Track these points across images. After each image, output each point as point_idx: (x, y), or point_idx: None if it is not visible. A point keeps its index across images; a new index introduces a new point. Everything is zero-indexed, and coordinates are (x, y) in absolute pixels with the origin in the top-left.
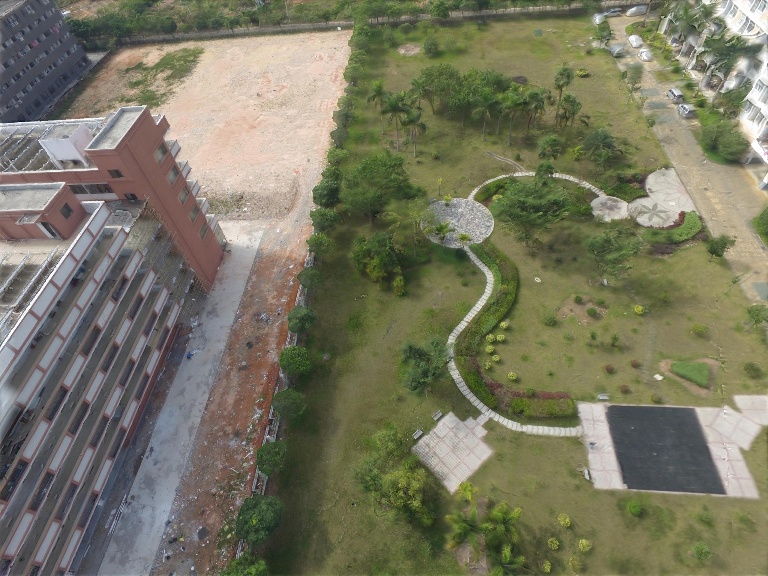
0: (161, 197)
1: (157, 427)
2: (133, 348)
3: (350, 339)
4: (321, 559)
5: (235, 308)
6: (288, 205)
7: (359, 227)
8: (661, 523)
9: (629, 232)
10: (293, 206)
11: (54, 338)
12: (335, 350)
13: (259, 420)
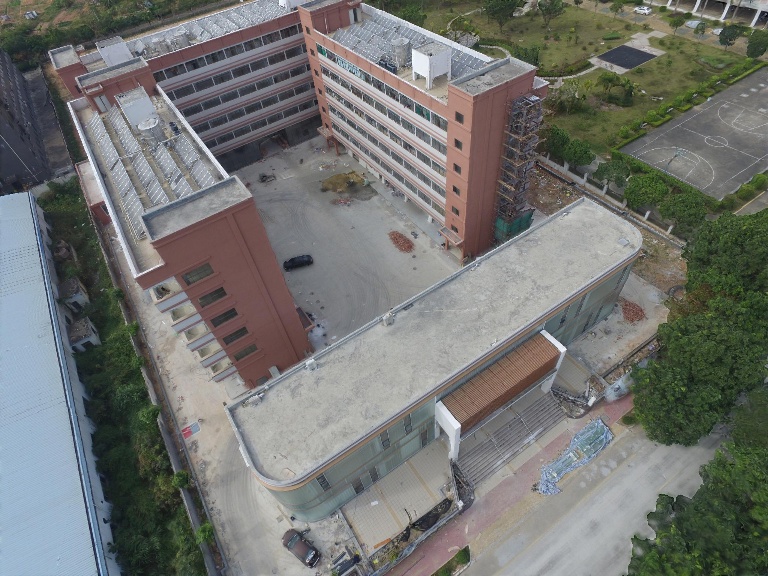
0: None
1: None
2: None
3: None
4: None
5: None
6: None
7: None
8: (649, 71)
9: None
10: None
11: None
12: None
13: None
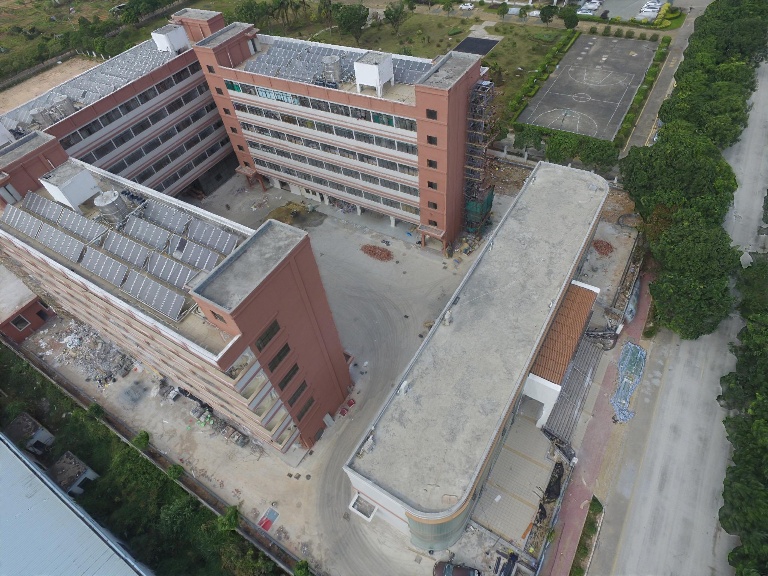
0: None
1: None
2: None
3: None
4: None
5: None
6: None
7: None
8: None
9: (393, 2)
10: None
11: None
12: None
13: None
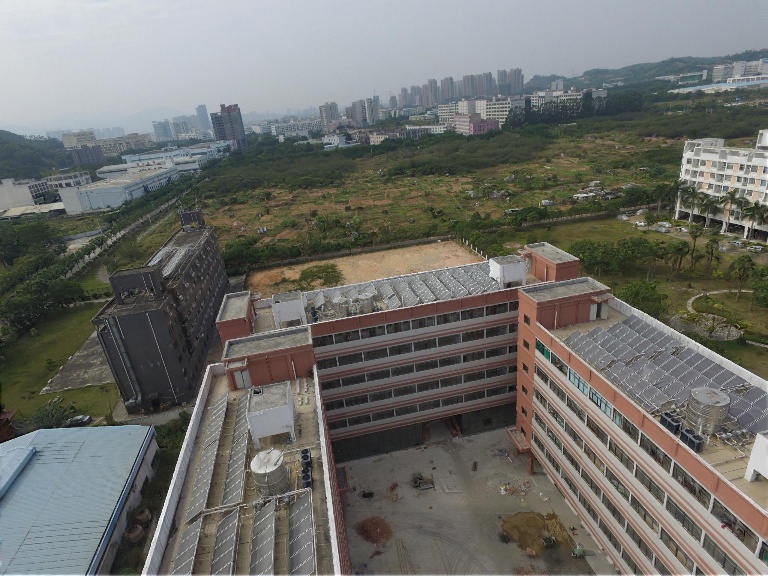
0: None
1: None
2: None
3: None
4: None
5: None
6: None
7: None
8: None
9: None
10: None
11: None
12: None
13: None
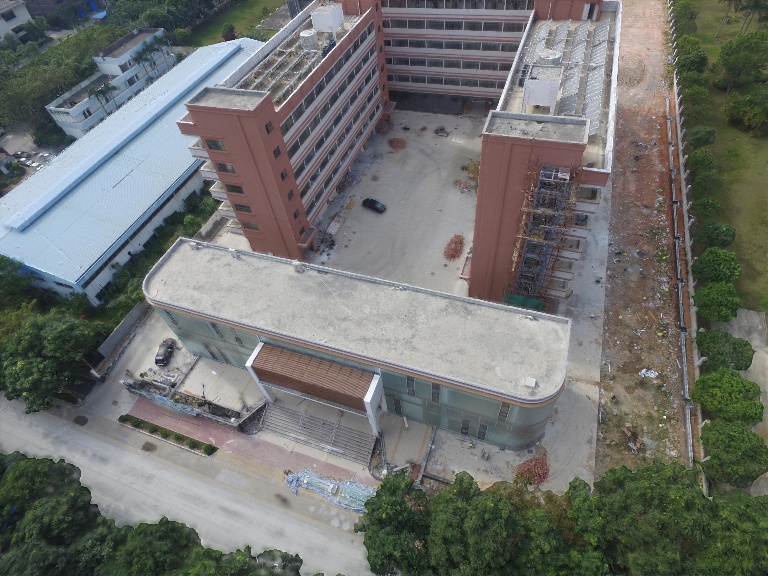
0: None
1: None
2: None
3: (733, 163)
4: (753, 277)
5: None
6: (638, 77)
7: (715, 96)
8: None
9: None
10: (642, 79)
11: None
12: (721, 168)
13: (664, 201)
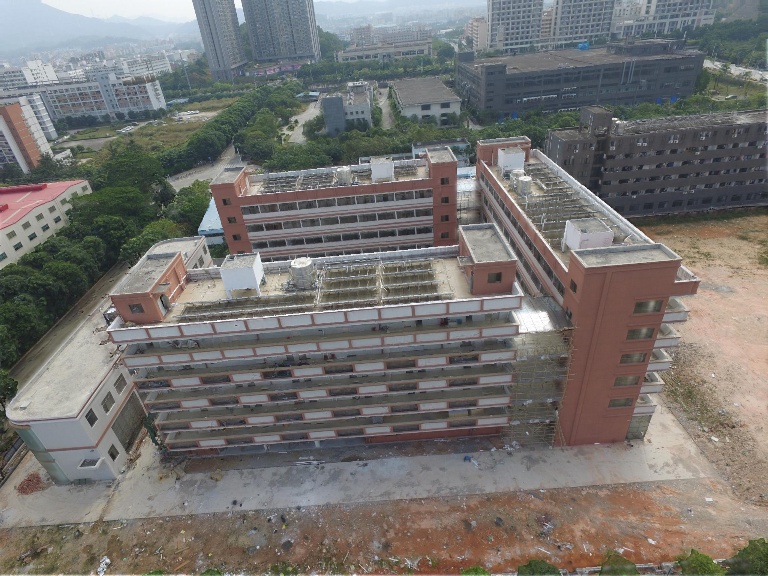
0: (597, 338)
1: (386, 460)
2: (428, 401)
3: None
4: None
5: (547, 485)
6: None
7: None
8: None
9: None
10: None
11: (377, 337)
12: None
13: (404, 568)
